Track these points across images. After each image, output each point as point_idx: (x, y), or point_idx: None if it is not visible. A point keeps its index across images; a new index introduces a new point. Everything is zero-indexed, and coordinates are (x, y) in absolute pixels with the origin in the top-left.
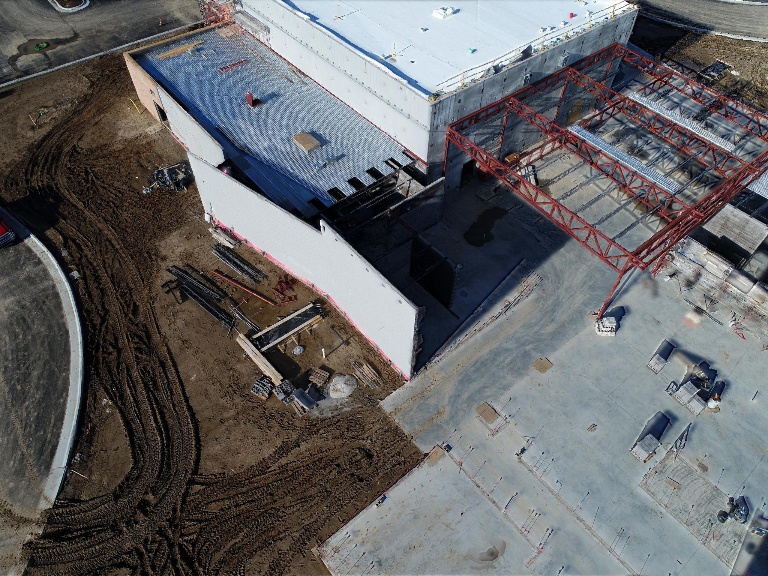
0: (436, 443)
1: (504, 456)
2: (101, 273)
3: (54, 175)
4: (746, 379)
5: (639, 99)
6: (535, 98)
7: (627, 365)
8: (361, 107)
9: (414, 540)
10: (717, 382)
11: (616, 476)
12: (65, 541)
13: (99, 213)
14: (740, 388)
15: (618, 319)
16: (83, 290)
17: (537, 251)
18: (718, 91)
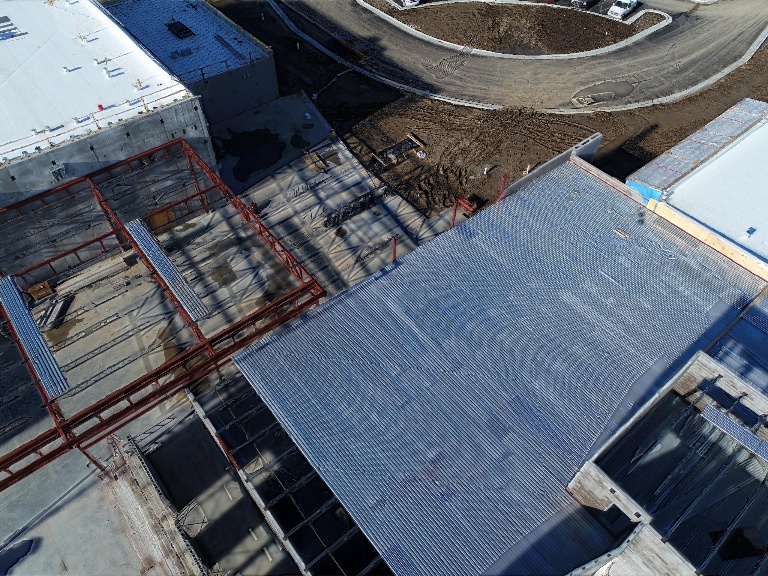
0: None
1: None
2: None
3: None
4: None
5: (133, 231)
6: (38, 219)
7: None
8: None
9: None
10: None
11: None
12: None
13: None
14: None
15: (10, 564)
16: None
17: None
18: (386, 181)
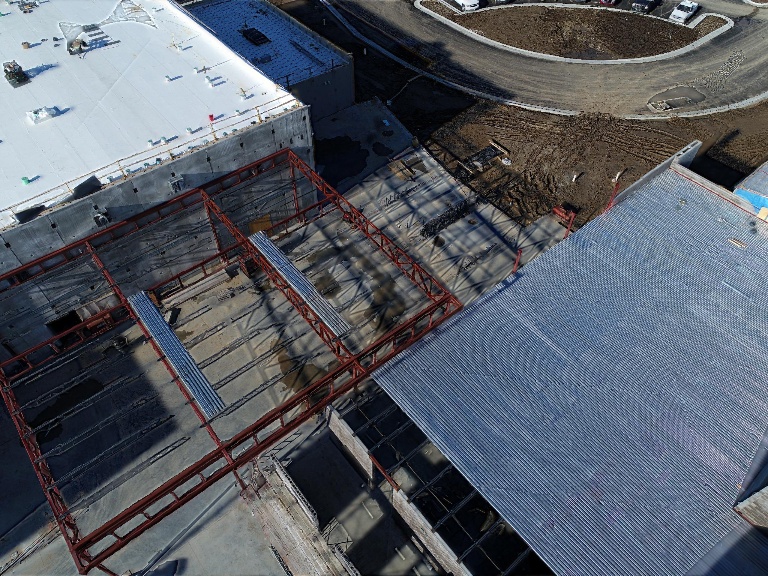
0: None
1: None
2: None
3: None
4: None
5: (259, 244)
6: (152, 231)
7: None
8: None
9: None
10: None
11: None
12: None
13: None
14: None
15: None
16: None
17: None
18: (475, 189)
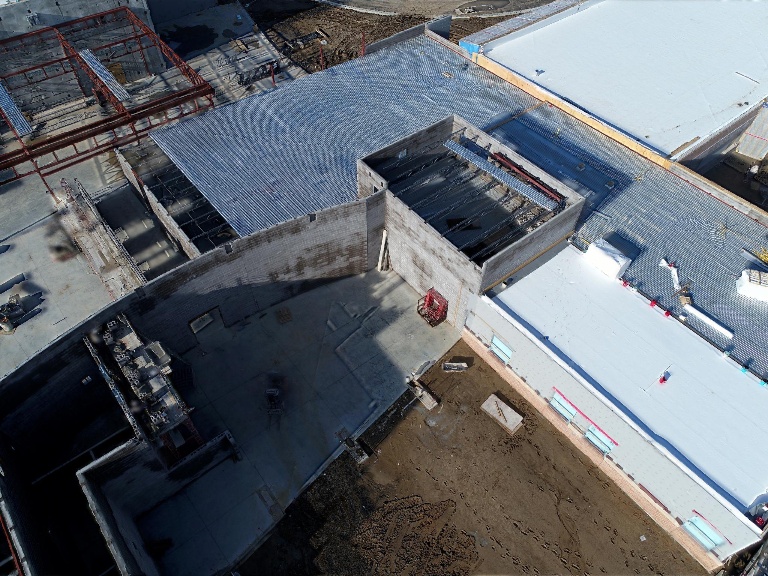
0: None
1: None
2: None
3: None
4: (65, 307)
5: (84, 55)
6: None
7: None
8: None
9: None
10: (35, 309)
11: None
12: None
13: None
14: (51, 315)
15: None
16: None
17: None
18: (292, 58)
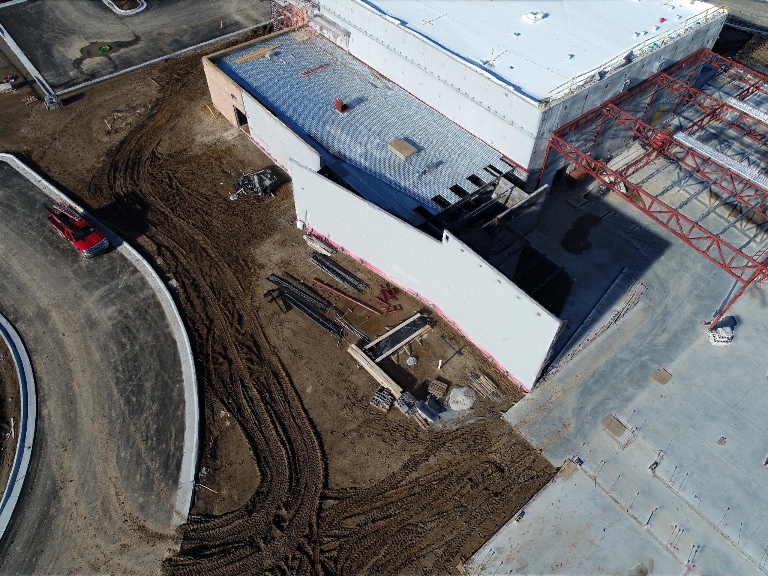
0: (566, 457)
1: (637, 470)
2: (200, 281)
3: (137, 181)
4: None
5: (738, 105)
6: (627, 104)
7: (747, 376)
8: (453, 113)
9: (560, 557)
10: None
11: (754, 491)
12: (204, 558)
13: (189, 220)
14: None
15: None
16: (184, 299)
17: (637, 259)
18: None
